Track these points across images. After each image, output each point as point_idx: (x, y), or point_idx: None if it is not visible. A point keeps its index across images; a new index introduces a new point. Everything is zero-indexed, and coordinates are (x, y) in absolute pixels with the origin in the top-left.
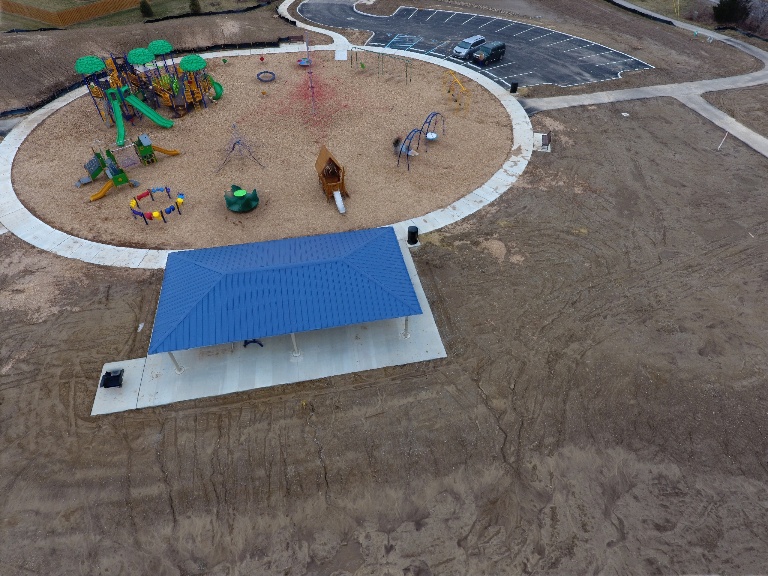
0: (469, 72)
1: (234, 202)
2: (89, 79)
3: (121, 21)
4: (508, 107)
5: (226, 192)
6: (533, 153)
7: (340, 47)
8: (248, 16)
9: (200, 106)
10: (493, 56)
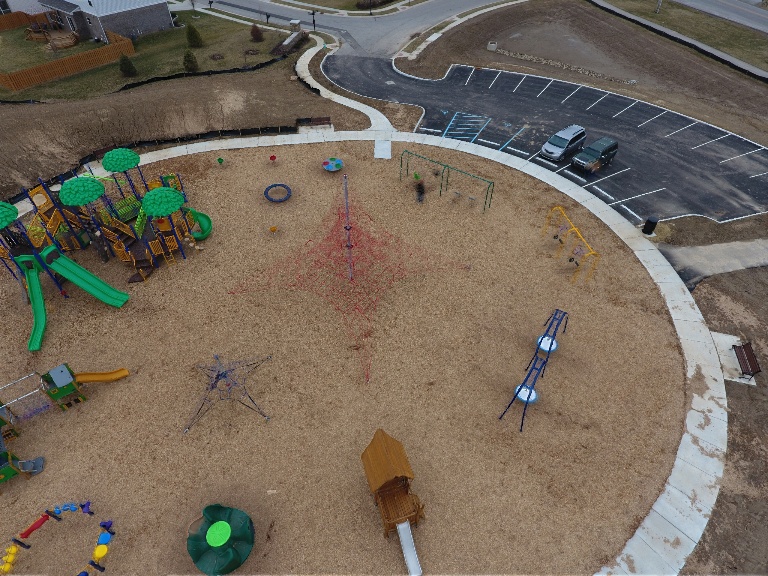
0: (570, 187)
1: (206, 548)
2: (23, 194)
3: (93, 83)
4: (649, 266)
5: (191, 533)
6: (727, 387)
7: (381, 135)
8: (257, 79)
9: (176, 253)
10: (601, 161)
